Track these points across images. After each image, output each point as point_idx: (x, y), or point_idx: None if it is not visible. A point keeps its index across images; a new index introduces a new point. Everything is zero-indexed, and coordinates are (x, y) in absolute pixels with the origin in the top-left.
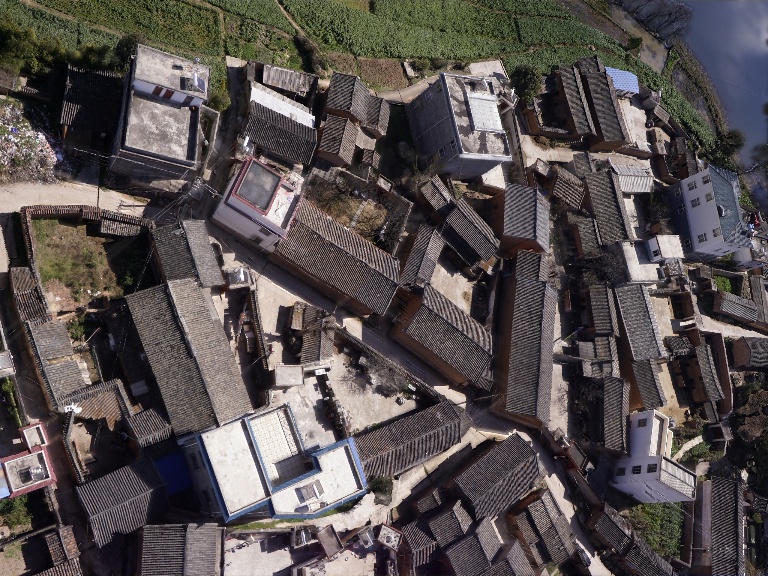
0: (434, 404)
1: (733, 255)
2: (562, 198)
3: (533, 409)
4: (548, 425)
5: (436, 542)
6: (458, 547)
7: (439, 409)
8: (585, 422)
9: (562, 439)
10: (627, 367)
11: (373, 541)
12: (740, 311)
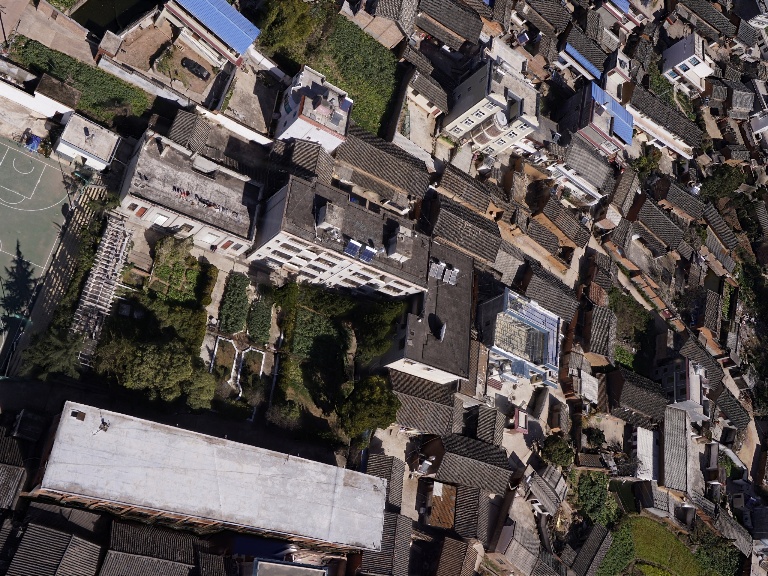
0: None
1: None
2: (758, 69)
3: None
4: (670, 26)
5: None
6: None
7: None
8: None
9: None
10: None
11: None
12: None
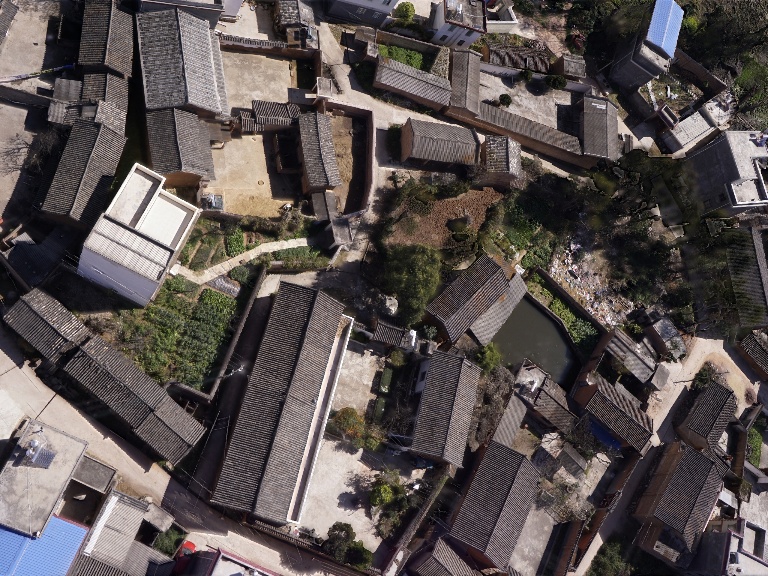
0: None
1: (432, 23)
2: None
3: None
4: None
5: None
6: None
7: None
8: None
9: None
10: None
11: None
12: (416, 87)
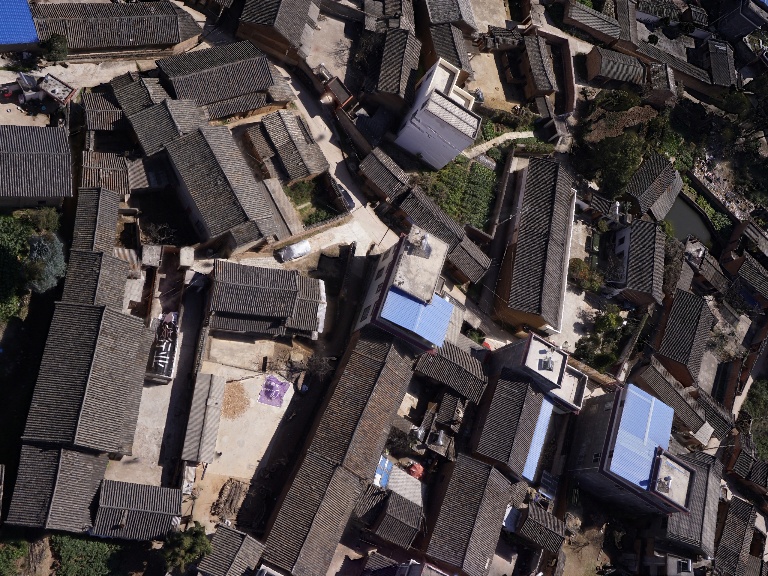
0: (150, 1)
1: None
2: None
3: (272, 20)
4: None
5: (121, 110)
6: (143, 113)
7: (155, 5)
8: (366, 76)
9: (321, 72)
10: (428, 36)
11: (35, 89)
12: (596, 23)
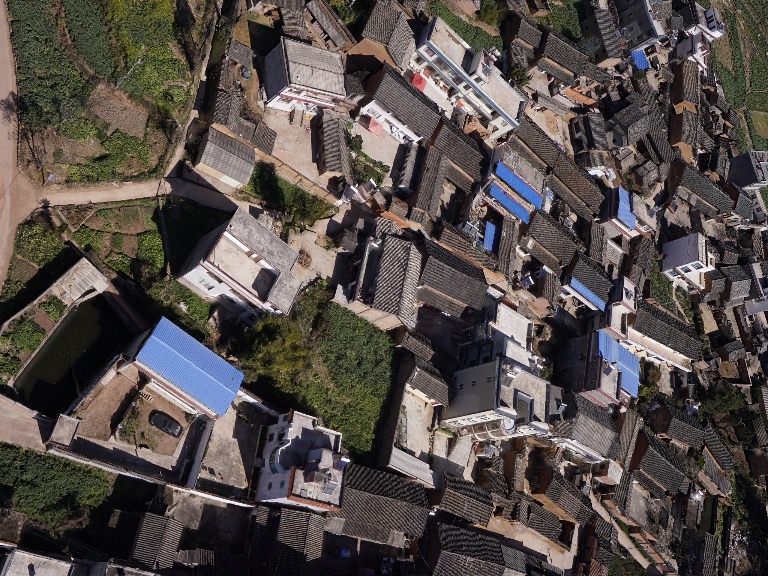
0: None
1: None
2: (753, 241)
3: None
4: None
5: None
6: None
7: None
8: None
9: None
10: None
11: None
12: None
